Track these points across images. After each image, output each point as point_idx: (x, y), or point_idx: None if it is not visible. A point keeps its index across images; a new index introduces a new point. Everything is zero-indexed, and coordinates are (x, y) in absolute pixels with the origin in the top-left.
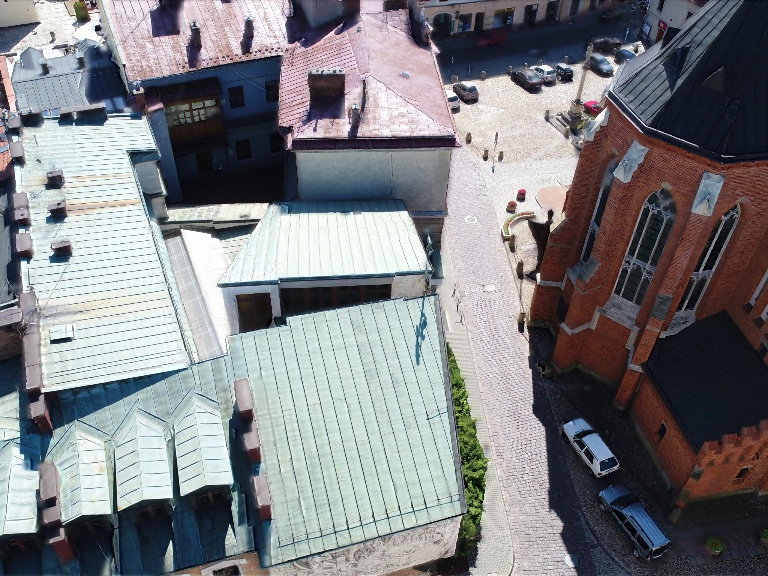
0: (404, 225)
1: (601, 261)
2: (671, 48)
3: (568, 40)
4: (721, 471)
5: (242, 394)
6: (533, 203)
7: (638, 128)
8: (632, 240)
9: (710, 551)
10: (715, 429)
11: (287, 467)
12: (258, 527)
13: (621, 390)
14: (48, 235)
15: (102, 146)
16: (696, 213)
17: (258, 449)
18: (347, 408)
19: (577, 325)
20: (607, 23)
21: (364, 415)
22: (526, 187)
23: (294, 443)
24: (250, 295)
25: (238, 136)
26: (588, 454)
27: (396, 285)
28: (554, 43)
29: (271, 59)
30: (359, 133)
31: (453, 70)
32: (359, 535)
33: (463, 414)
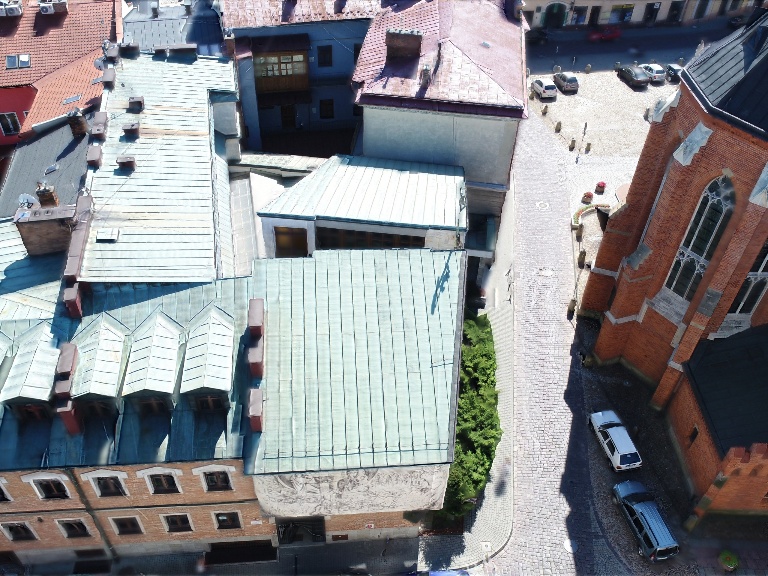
0: (455, 188)
1: (653, 248)
2: (754, 28)
3: (688, 43)
4: (748, 484)
5: (255, 311)
6: (611, 197)
7: (704, 108)
8: (688, 230)
9: (722, 565)
10: (747, 438)
11: (286, 387)
12: (249, 437)
13: (659, 389)
14: (118, 151)
15: (186, 82)
16: (754, 203)
17: (260, 364)
18: (354, 343)
19: (622, 315)
20: (735, 29)
21: (369, 352)
22: (608, 181)
23: (297, 367)
24: (288, 229)
25: (322, 95)
26: (611, 446)
27: (430, 239)
28: (672, 44)
29: (361, 21)
30: (427, 94)
31: (558, 61)
32: (342, 463)
33: (487, 384)
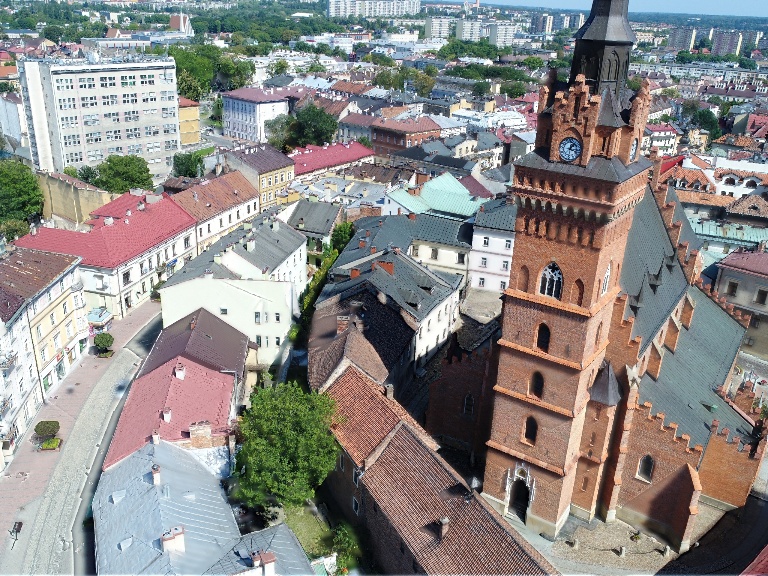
0: None
1: None
2: None
3: None
4: None
5: None
6: None
7: None
8: None
9: None
10: None
11: None
12: None
13: None
14: None
15: (765, 239)
16: None
17: None
18: None
19: None
20: None
21: None
22: None
23: None
24: None
25: None
26: None
27: None
28: None
29: None
30: None
31: None
32: None
33: None
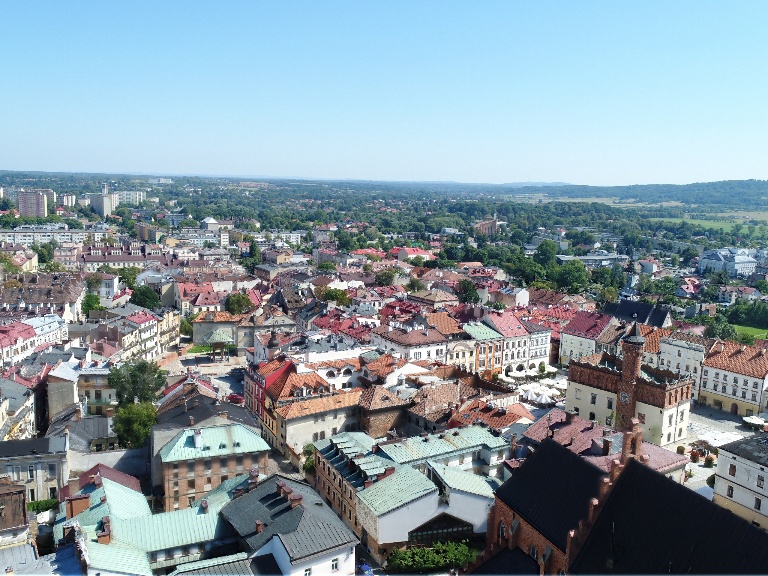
0: None
1: None
2: None
3: None
4: None
5: None
6: None
7: None
8: None
9: None
10: None
11: None
12: None
13: None
14: None
15: None
16: None
17: (378, 476)
18: None
19: None
20: None
21: None
22: None
23: None
24: None
25: None
26: None
27: None
28: None
29: None
30: None
31: None
32: None
33: None
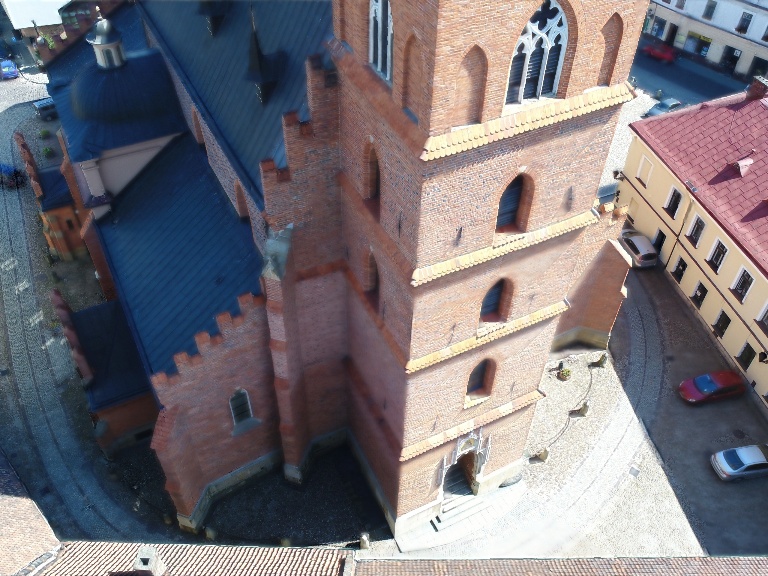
0: None
1: None
2: None
3: None
4: None
5: None
6: None
7: None
8: None
9: None
10: None
11: None
12: None
13: None
14: None
15: None
16: None
17: None
18: None
19: None
20: None
21: None
22: None
23: None
24: None
25: None
26: None
27: None
28: (706, 91)
29: None
30: None
31: None
32: None
33: None
